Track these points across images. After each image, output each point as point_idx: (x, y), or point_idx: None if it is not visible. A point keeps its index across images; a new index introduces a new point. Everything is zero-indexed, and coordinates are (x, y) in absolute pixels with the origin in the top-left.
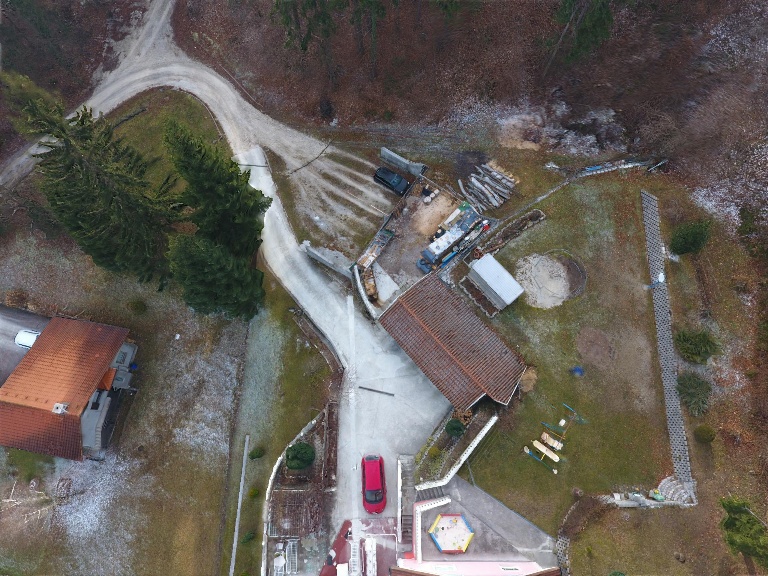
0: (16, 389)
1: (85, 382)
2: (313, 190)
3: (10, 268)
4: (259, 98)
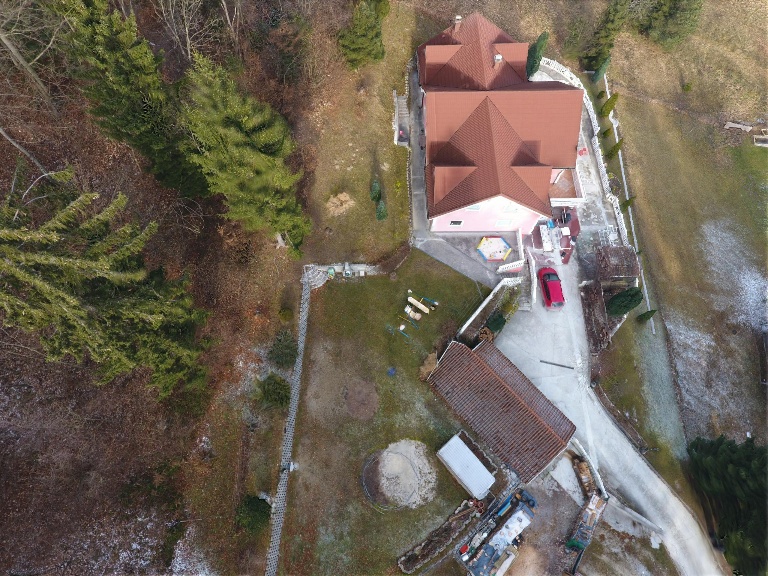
0: None
1: None
2: None
3: None
4: None
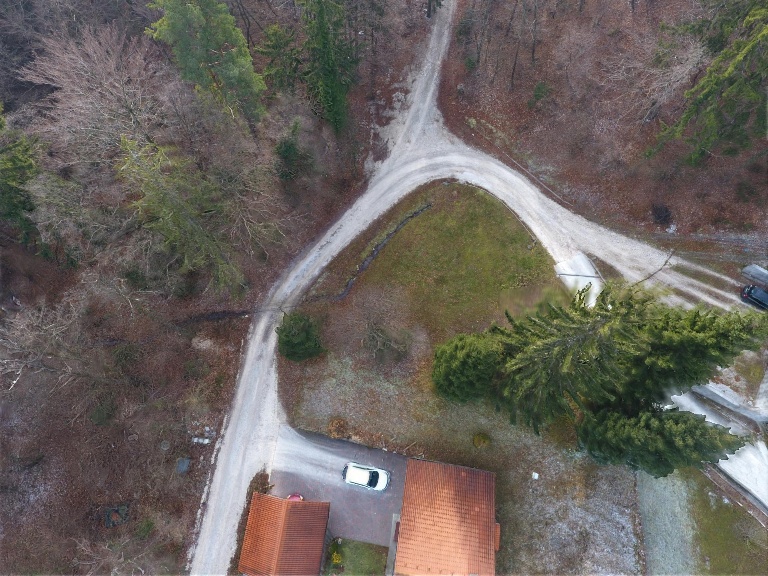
0: (413, 558)
1: (481, 546)
2: (667, 308)
3: (326, 393)
4: (566, 196)
